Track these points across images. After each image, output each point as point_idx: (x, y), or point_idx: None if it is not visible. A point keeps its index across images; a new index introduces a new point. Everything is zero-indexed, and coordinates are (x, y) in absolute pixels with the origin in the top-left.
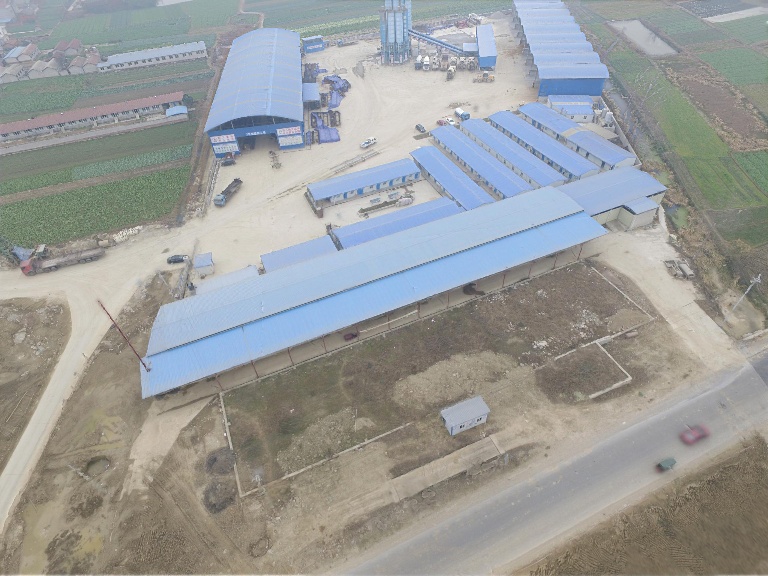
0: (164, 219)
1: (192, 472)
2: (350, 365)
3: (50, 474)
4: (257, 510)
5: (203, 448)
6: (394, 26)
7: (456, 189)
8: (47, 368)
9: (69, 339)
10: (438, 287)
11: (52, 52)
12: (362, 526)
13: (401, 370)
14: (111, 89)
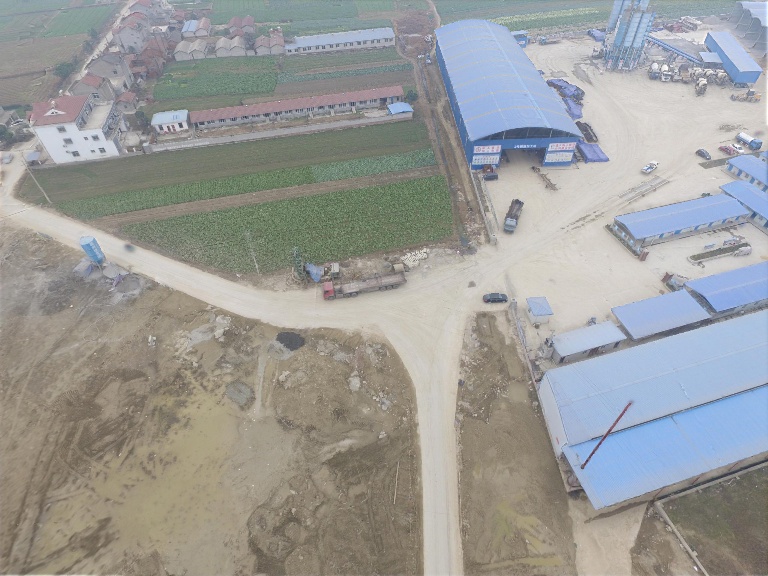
0: (447, 242)
1: None
2: None
3: None
4: None
5: None
6: (636, 28)
7: None
8: (410, 432)
9: (416, 393)
10: None
11: (229, 28)
12: None
13: None
14: (308, 75)
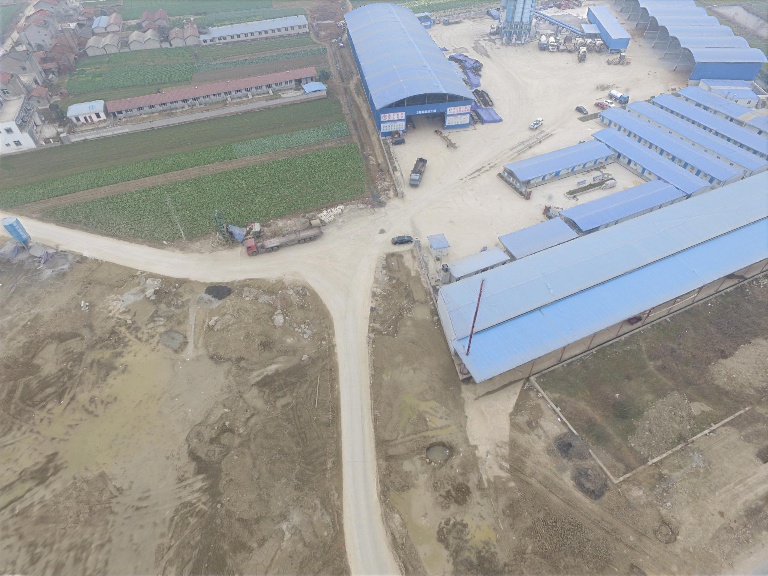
0: (360, 199)
1: (547, 458)
2: (651, 349)
3: (396, 461)
4: (641, 496)
5: (544, 433)
6: (523, 4)
7: (664, 172)
8: (328, 351)
9: (333, 322)
10: (719, 271)
11: (141, 23)
12: (762, 511)
13: (709, 354)
14: (224, 63)
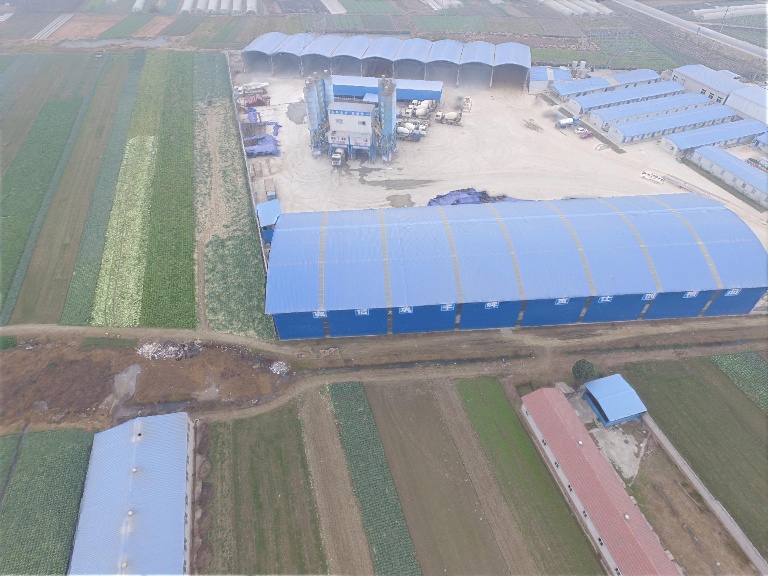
0: None
1: None
2: None
3: None
4: None
5: None
6: None
7: (742, 131)
8: None
9: None
10: None
11: None
12: None
13: None
14: None
